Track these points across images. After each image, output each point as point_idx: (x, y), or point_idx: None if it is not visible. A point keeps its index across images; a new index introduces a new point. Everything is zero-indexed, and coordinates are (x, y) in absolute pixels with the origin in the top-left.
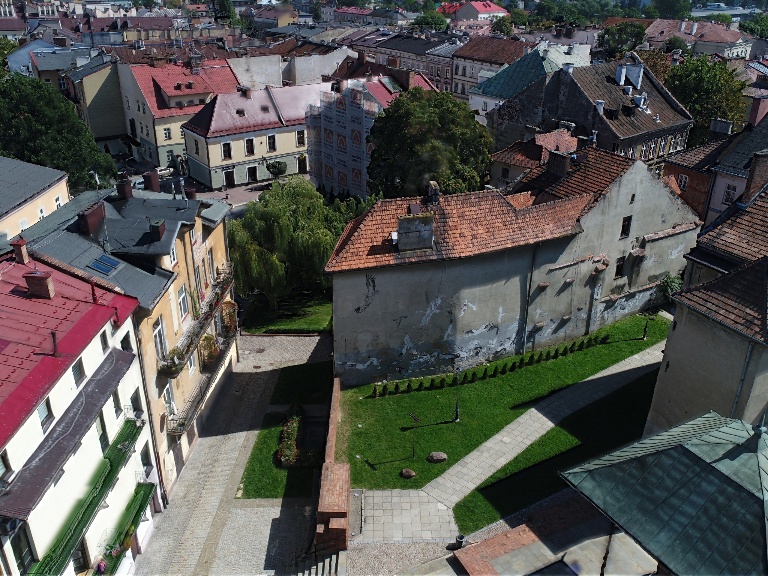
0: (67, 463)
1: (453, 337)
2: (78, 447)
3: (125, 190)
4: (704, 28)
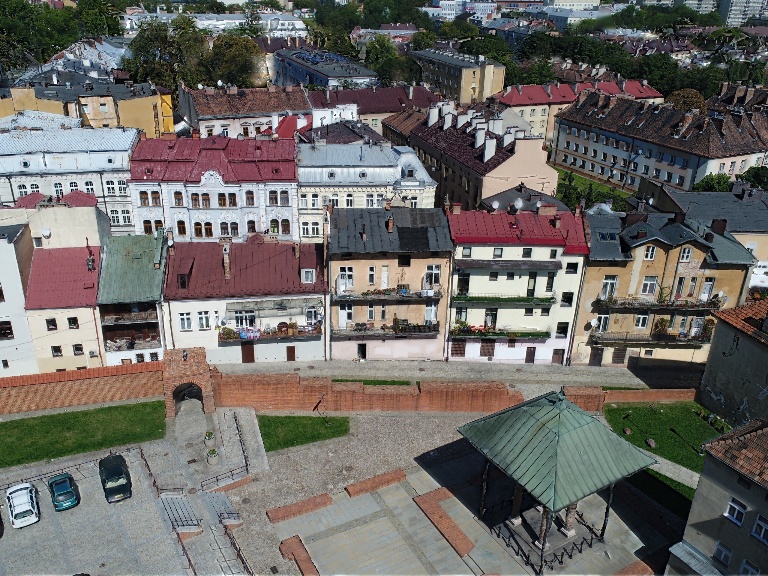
0: (501, 279)
1: None
2: (512, 279)
3: (677, 217)
4: None
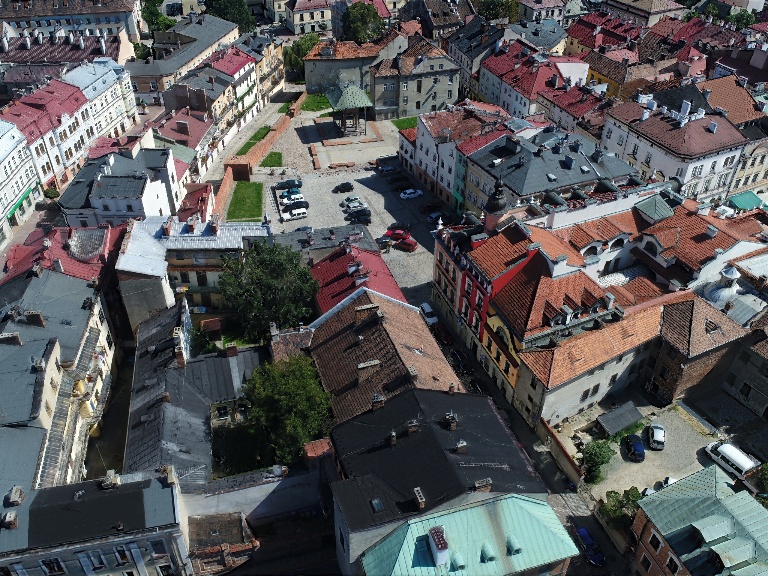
0: None
1: (339, 83)
2: None
3: (256, 34)
4: None
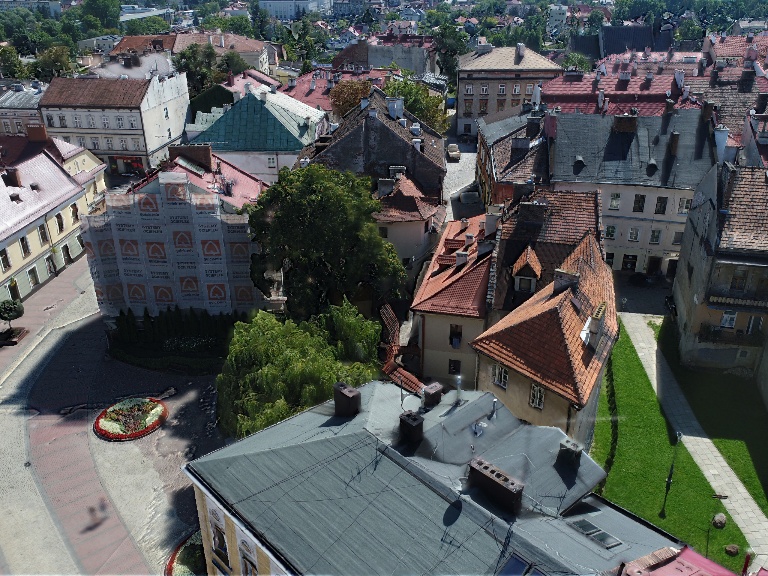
0: None
1: None
2: None
3: None
4: (229, 39)
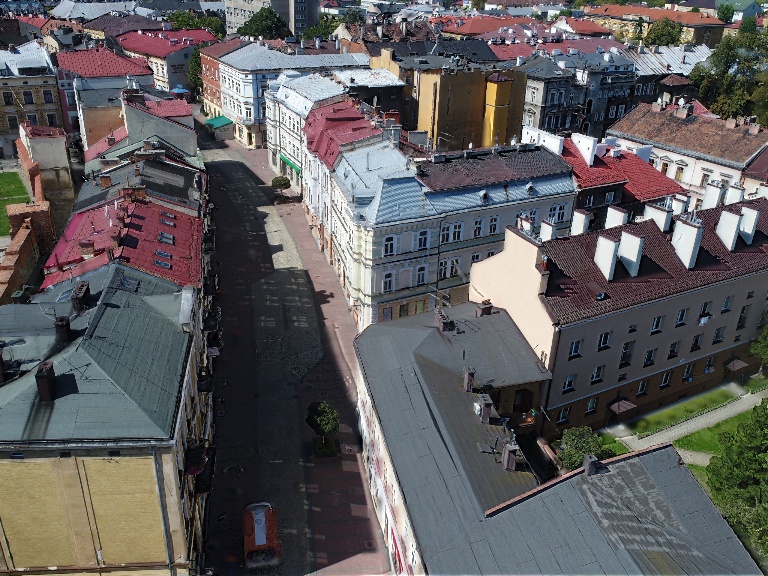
0: None
1: None
2: None
3: None
4: None
